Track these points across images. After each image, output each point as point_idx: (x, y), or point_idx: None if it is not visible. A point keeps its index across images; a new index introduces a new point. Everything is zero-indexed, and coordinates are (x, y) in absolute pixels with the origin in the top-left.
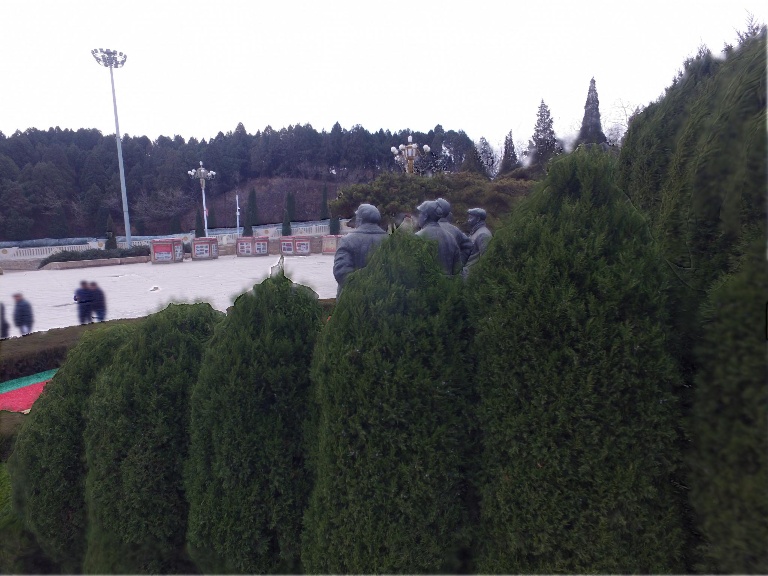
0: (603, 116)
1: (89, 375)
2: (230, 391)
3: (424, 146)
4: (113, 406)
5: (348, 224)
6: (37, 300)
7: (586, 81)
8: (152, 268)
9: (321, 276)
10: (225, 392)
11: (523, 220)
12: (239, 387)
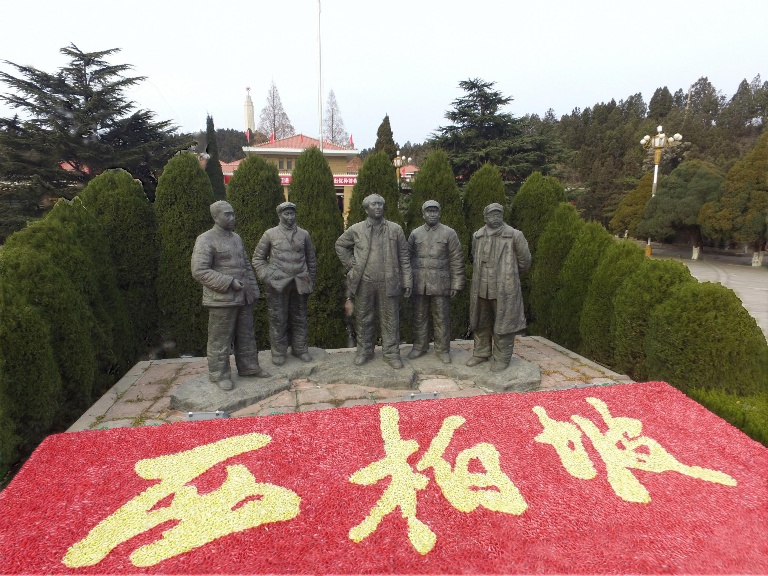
0: None
1: None
2: None
3: None
4: None
5: None
6: None
7: None
8: None
9: None
10: None
11: (581, 220)
12: None
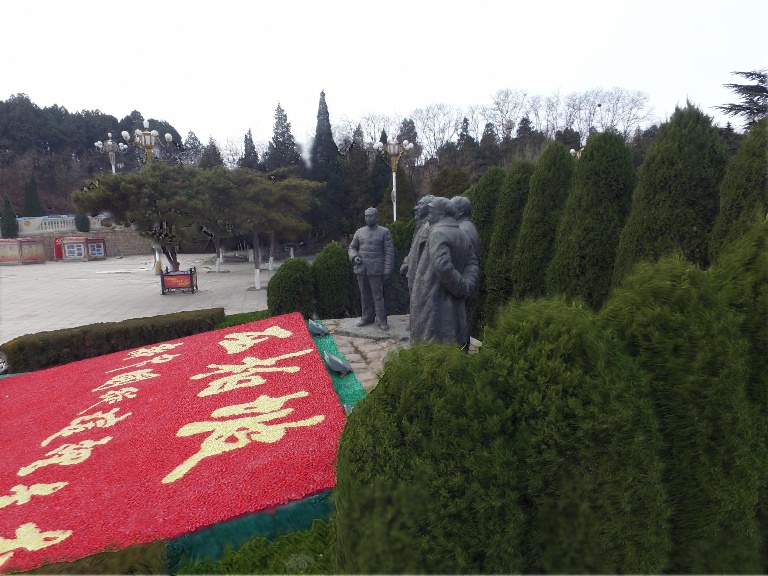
0: (333, 127)
1: (488, 412)
2: (728, 372)
3: (166, 134)
4: (615, 427)
5: (103, 223)
6: None
7: (316, 93)
8: None
9: (43, 292)
10: (722, 375)
11: None
12: (738, 366)
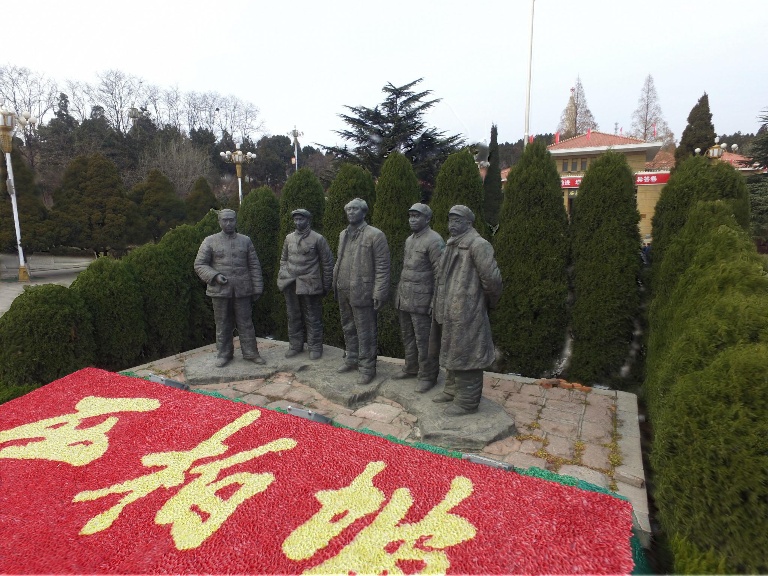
0: None
1: None
2: None
3: None
4: None
5: None
6: None
7: None
8: None
9: None
10: None
11: None
12: None
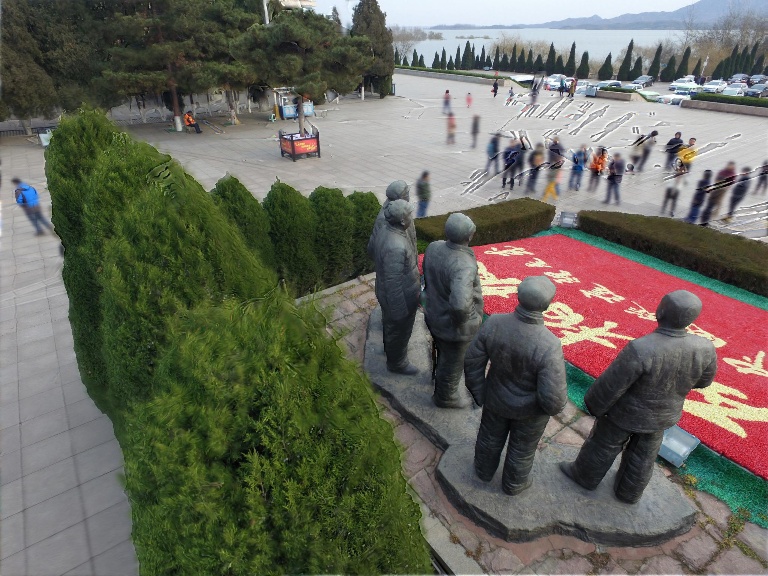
0: None
1: None
2: None
3: None
4: None
5: None
6: None
7: None
8: None
9: None
10: None
11: None
12: None
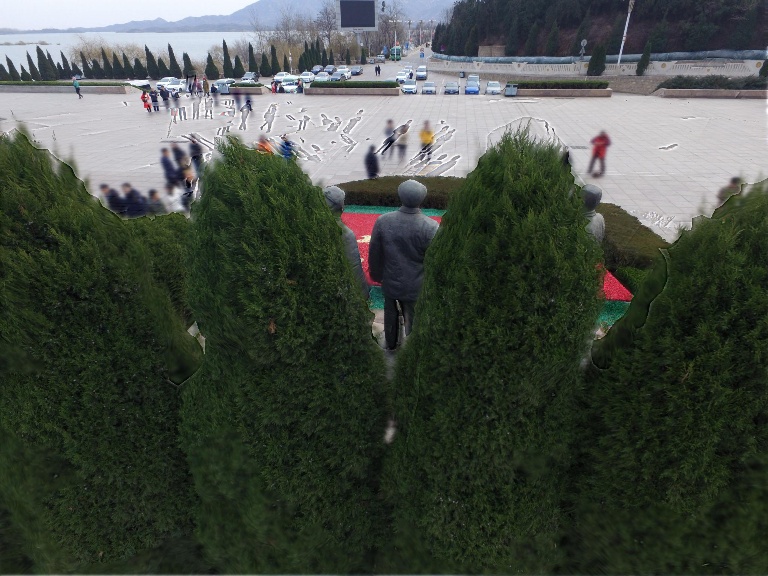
0: None
1: None
2: None
3: None
4: None
5: None
6: (560, 136)
7: None
8: (753, 111)
9: None
10: None
11: None
12: None
